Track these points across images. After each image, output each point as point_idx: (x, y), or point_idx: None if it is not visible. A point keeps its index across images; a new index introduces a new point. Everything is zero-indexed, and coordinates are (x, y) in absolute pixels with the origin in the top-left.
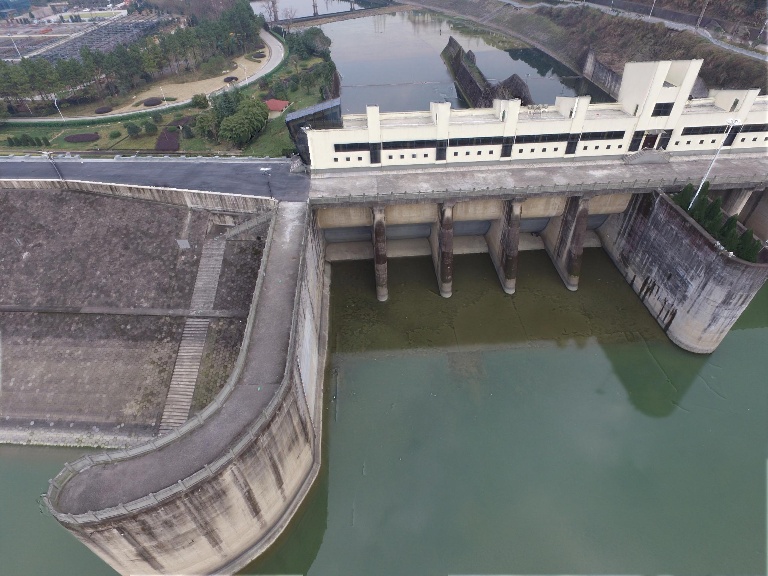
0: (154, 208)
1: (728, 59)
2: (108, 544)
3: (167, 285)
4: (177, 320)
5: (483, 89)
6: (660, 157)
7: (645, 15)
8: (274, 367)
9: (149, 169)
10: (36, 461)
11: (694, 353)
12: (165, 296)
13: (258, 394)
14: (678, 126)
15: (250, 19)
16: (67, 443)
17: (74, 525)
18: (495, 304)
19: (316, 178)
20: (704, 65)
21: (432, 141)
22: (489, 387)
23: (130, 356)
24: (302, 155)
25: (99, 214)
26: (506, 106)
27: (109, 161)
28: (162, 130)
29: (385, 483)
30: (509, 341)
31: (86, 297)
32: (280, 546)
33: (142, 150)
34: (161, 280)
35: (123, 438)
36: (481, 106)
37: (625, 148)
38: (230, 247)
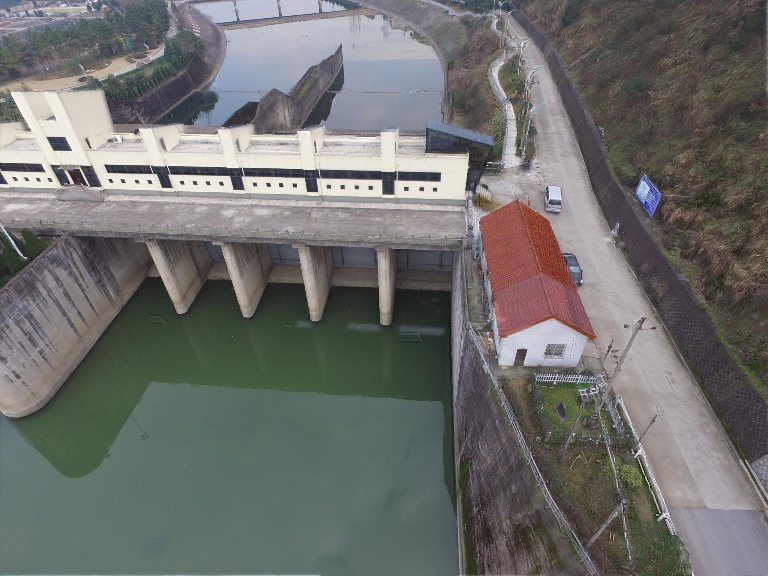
0: None
1: (473, 84)
2: None
3: None
4: None
5: None
6: (89, 195)
7: None
8: None
9: None
10: None
11: (4, 415)
12: None
13: None
14: (96, 163)
15: (144, 20)
16: None
17: None
18: None
19: None
20: (464, 89)
21: None
22: None
23: None
24: None
25: None
26: None
27: None
28: None
29: None
30: None
31: None
32: None
33: None
34: None
35: None
36: None
37: (57, 182)
38: None
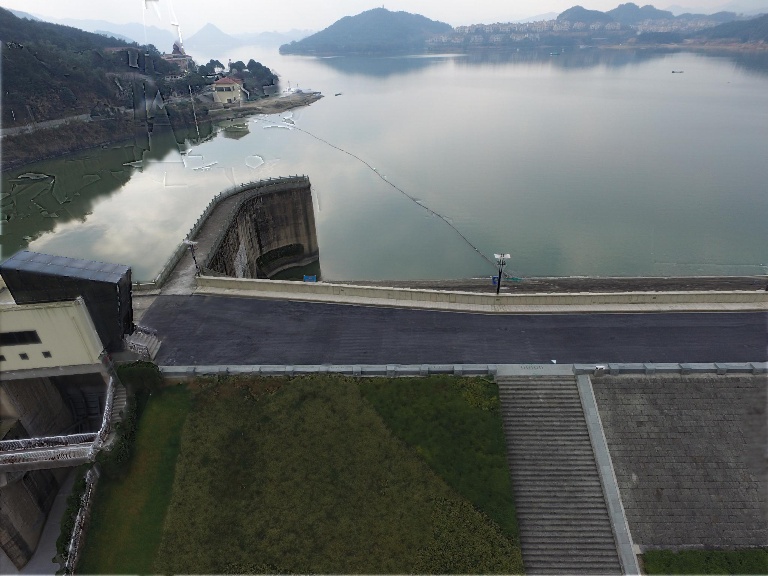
0: None
1: None
2: None
3: None
4: None
5: None
6: None
7: None
8: None
9: (406, 345)
10: None
11: None
12: None
13: (232, 201)
14: None
15: None
16: None
17: None
18: None
19: None
20: None
21: None
22: None
23: None
24: None
25: None
26: None
27: (504, 365)
28: None
29: None
30: None
31: None
32: None
33: None
34: None
35: None
36: None
37: None
38: None
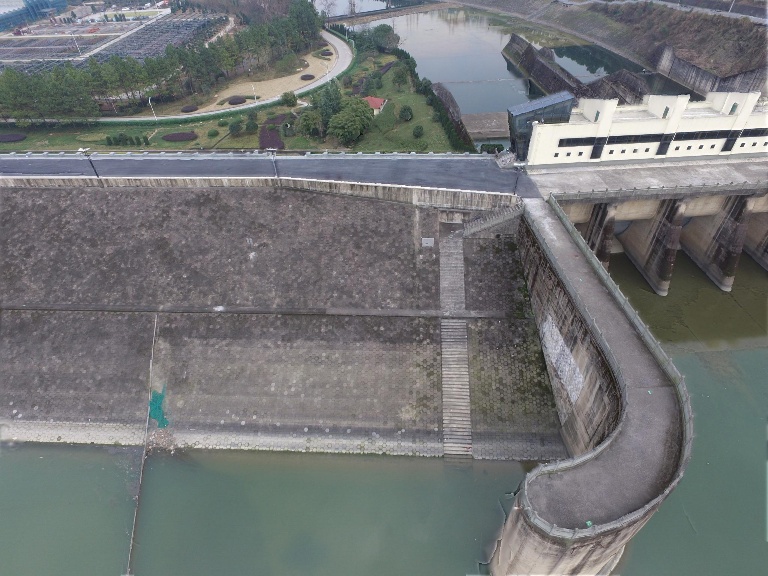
0: (378, 206)
1: None
2: (568, 559)
3: (411, 285)
4: (432, 321)
5: (576, 85)
6: None
7: (723, 10)
8: (648, 369)
9: (349, 166)
10: (322, 469)
11: None
12: (412, 296)
13: (653, 398)
14: None
15: None
16: (349, 450)
17: (570, 540)
18: (717, 302)
19: (534, 174)
20: None
21: (658, 135)
22: (756, 387)
23: (392, 359)
24: (518, 150)
25: (321, 212)
26: (741, 99)
27: (300, 158)
28: (260, 128)
29: (706, 488)
30: (753, 340)
31: (328, 298)
32: (628, 556)
33: (247, 149)
34: (403, 280)
35: (408, 444)
36: (575, 102)
37: None
38: (468, 245)
